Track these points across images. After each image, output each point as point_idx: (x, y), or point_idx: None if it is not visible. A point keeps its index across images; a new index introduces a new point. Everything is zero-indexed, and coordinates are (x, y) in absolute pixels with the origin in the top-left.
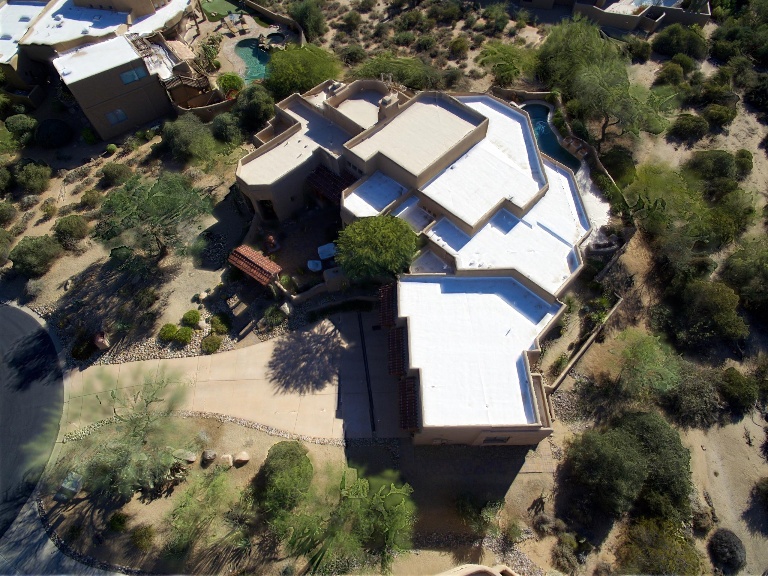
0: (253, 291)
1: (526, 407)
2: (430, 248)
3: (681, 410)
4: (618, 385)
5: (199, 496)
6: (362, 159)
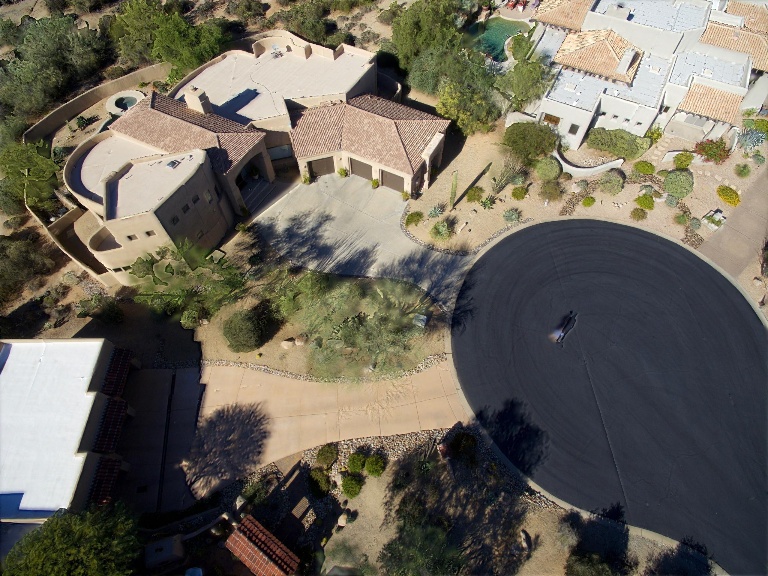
0: (285, 537)
1: (5, 360)
2: None
3: None
4: None
5: None
6: None
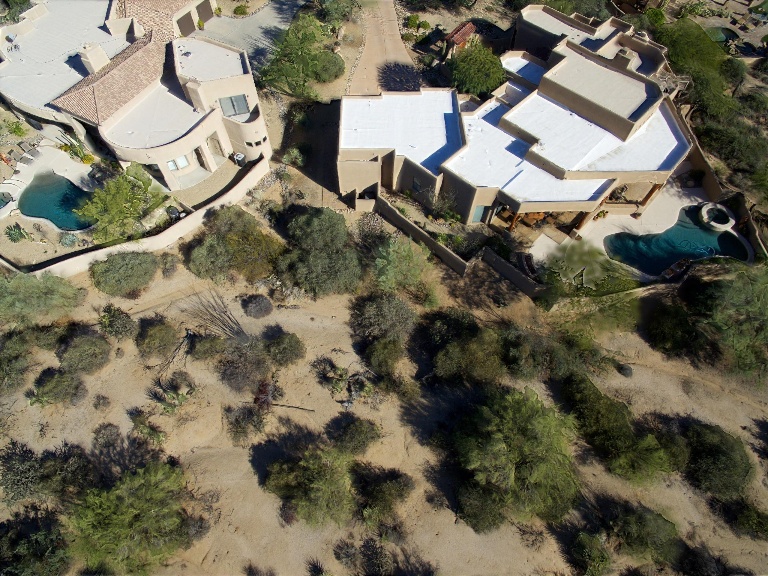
0: None
1: None
2: None
3: None
4: None
5: (321, 44)
6: (555, 48)
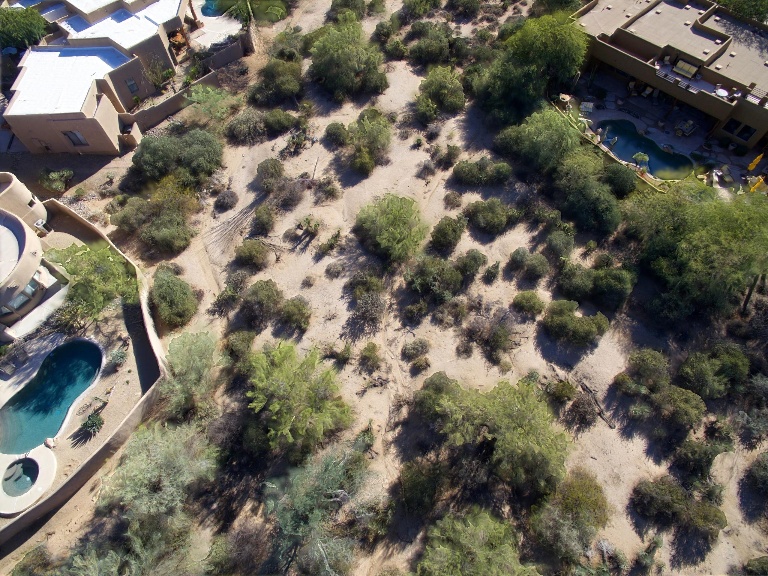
0: None
1: None
2: (63, 33)
3: (236, 135)
4: (203, 127)
5: None
6: None
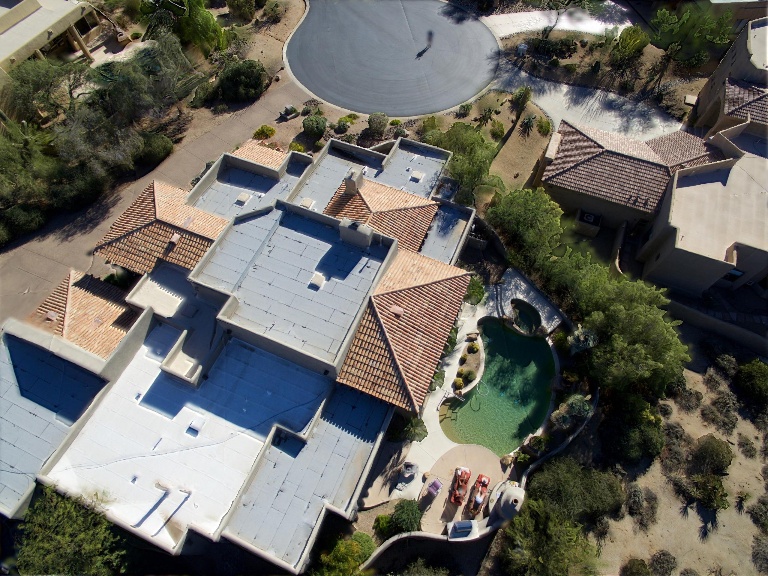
0: None
1: None
2: None
3: None
4: None
5: (587, 58)
6: None
